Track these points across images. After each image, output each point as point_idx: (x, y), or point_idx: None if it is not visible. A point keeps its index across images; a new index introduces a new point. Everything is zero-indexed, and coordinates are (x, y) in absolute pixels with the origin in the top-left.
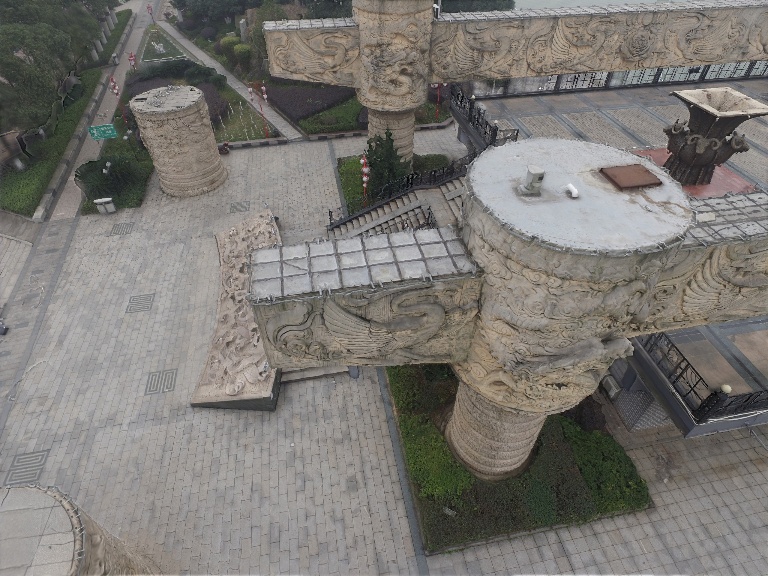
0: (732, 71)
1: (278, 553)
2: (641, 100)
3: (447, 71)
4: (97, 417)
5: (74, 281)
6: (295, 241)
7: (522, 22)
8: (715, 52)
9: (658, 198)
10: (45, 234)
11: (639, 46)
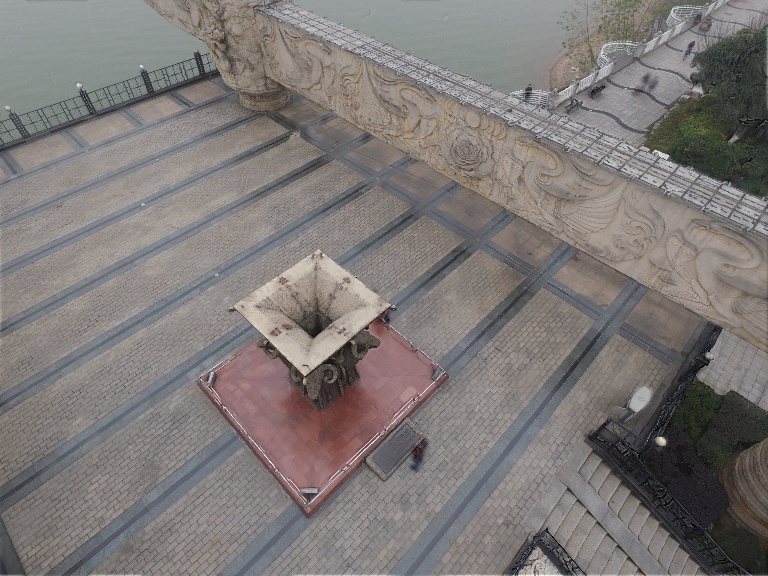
0: None
1: None
2: None
3: None
4: None
5: None
6: None
7: None
8: None
9: None
10: None
11: None
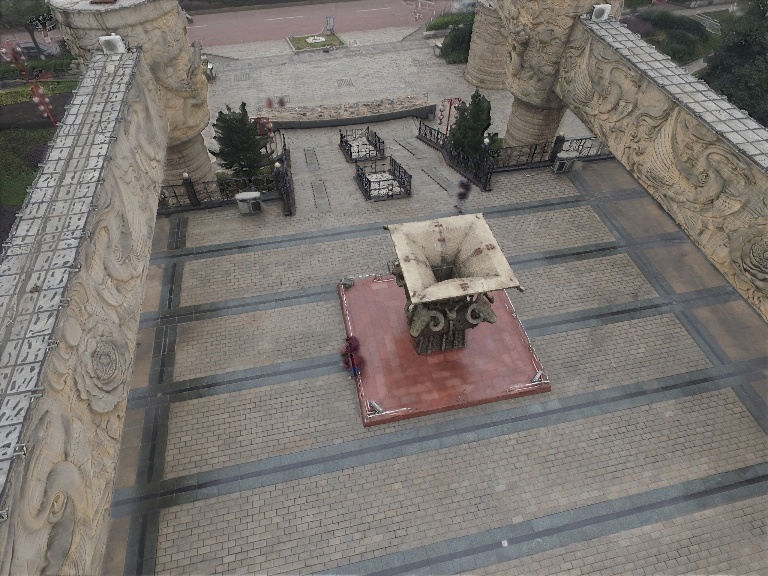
0: None
1: None
2: (766, 388)
3: (568, 87)
4: (264, 87)
5: (366, 60)
6: (403, 124)
7: (641, 79)
8: None
9: (81, 3)
10: (411, 42)
11: (761, 258)
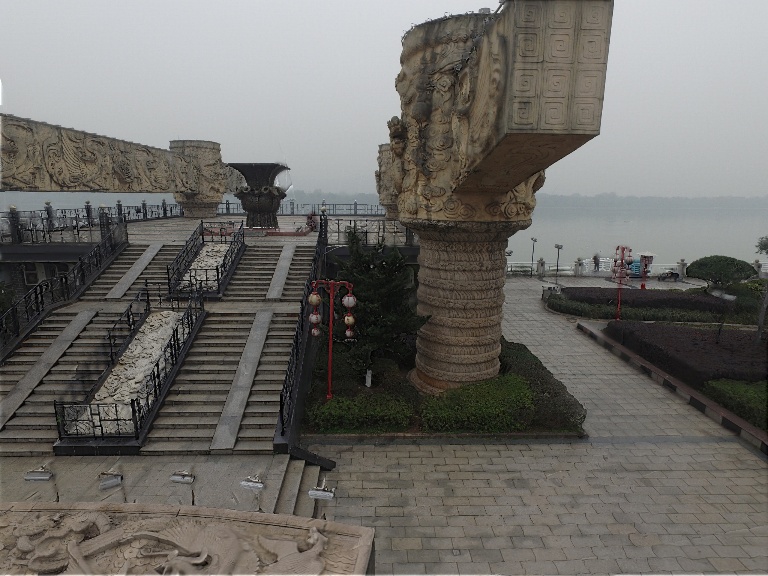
0: (157, 212)
1: (660, 574)
2: None
3: None
4: None
5: None
6: None
7: (28, 125)
8: (163, 183)
9: None
10: None
11: (126, 169)
